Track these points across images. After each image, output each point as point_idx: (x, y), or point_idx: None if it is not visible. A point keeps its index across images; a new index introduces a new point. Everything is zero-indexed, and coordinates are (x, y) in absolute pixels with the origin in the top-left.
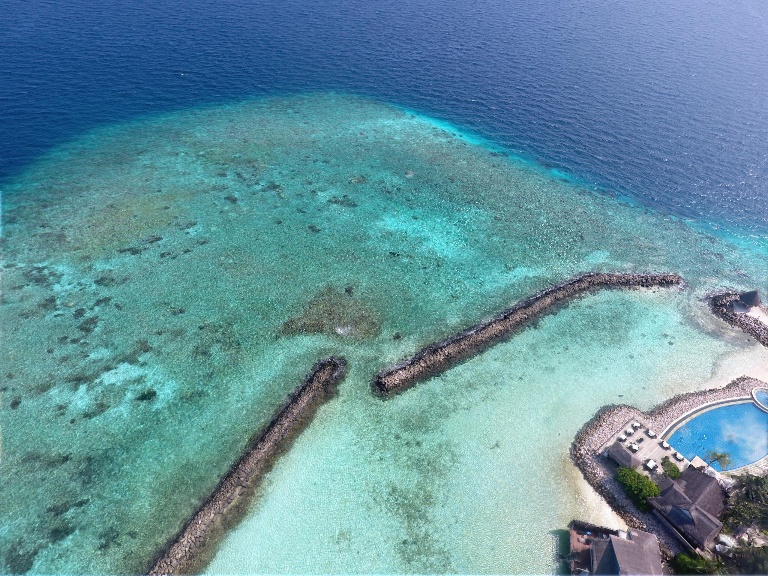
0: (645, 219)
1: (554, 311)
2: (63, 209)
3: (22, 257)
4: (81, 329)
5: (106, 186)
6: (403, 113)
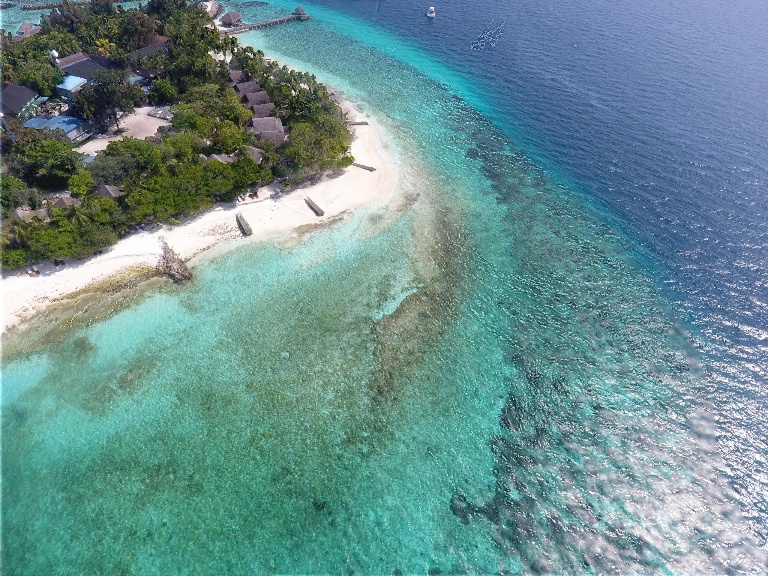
0: None
1: (122, 2)
2: None
3: None
4: None
5: None
6: None
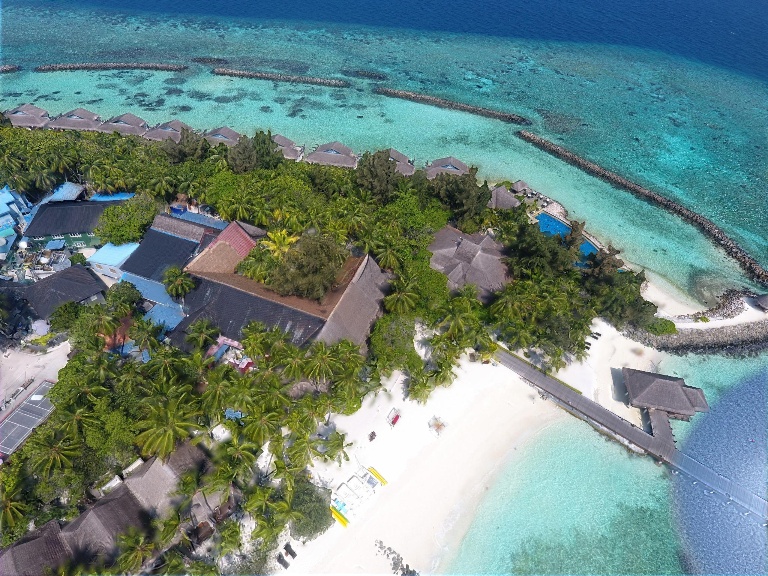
0: None
1: (640, 198)
2: (571, 54)
3: (531, 54)
4: (502, 70)
5: (600, 59)
6: None
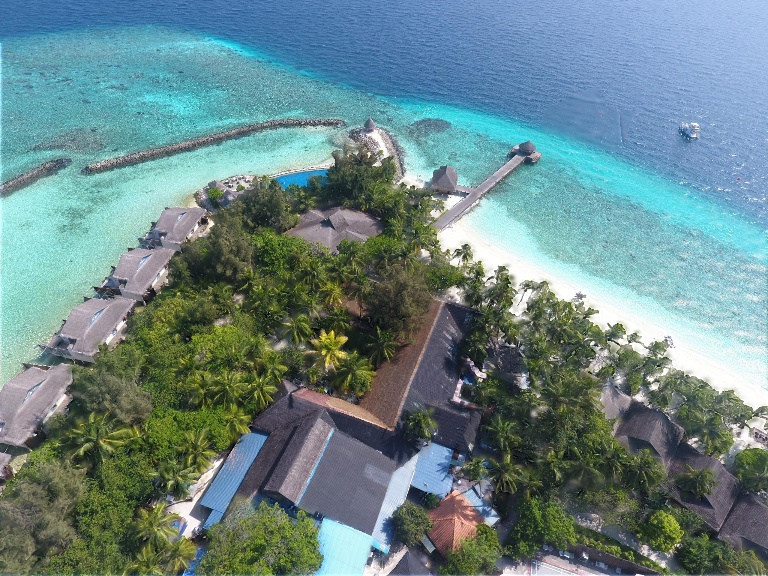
0: (347, 95)
1: (237, 138)
2: None
3: None
4: None
5: None
6: (202, 38)
